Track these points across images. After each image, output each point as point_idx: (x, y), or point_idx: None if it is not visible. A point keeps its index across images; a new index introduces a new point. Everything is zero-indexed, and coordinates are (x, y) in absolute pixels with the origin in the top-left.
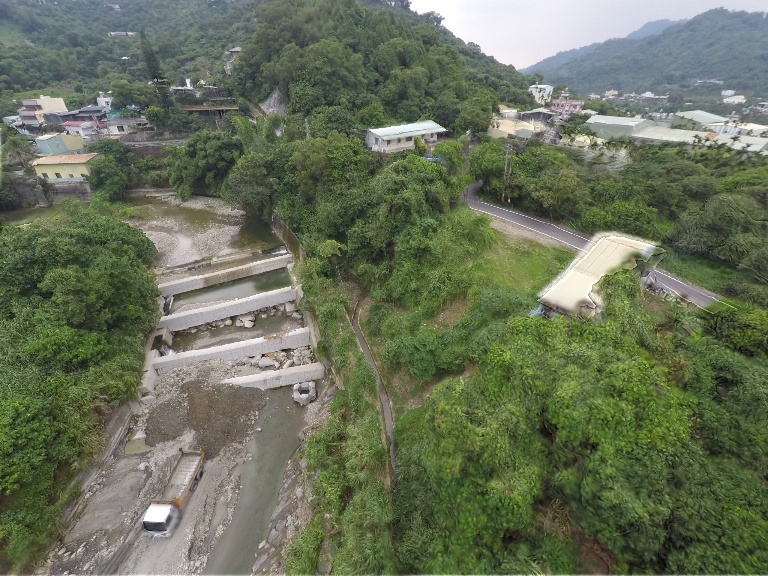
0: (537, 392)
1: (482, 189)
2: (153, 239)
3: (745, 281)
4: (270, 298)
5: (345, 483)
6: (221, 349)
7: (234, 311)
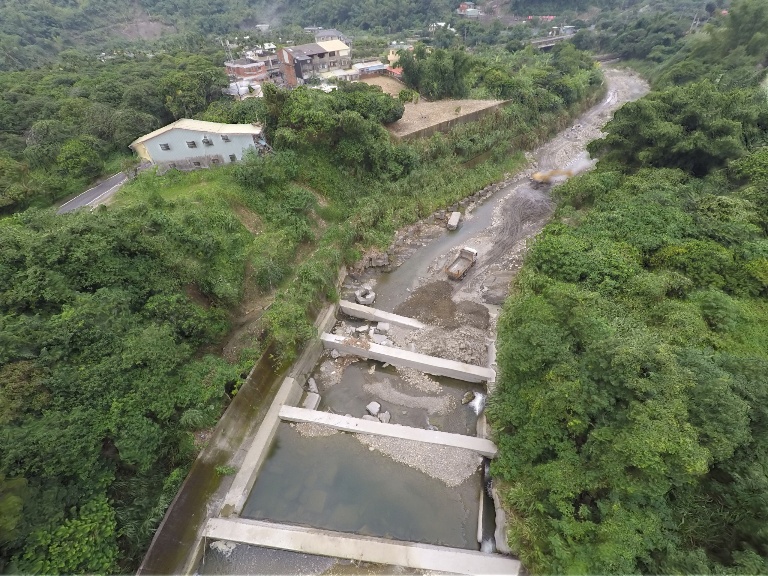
0: (327, 106)
1: None
2: None
3: (116, 155)
4: None
5: None
6: (417, 355)
7: None
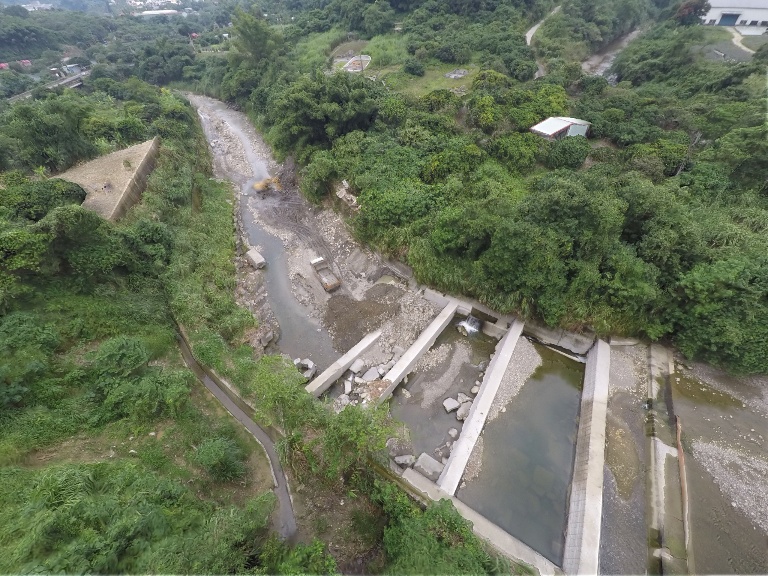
0: None
1: None
2: None
3: None
4: None
5: None
6: (416, 344)
7: None
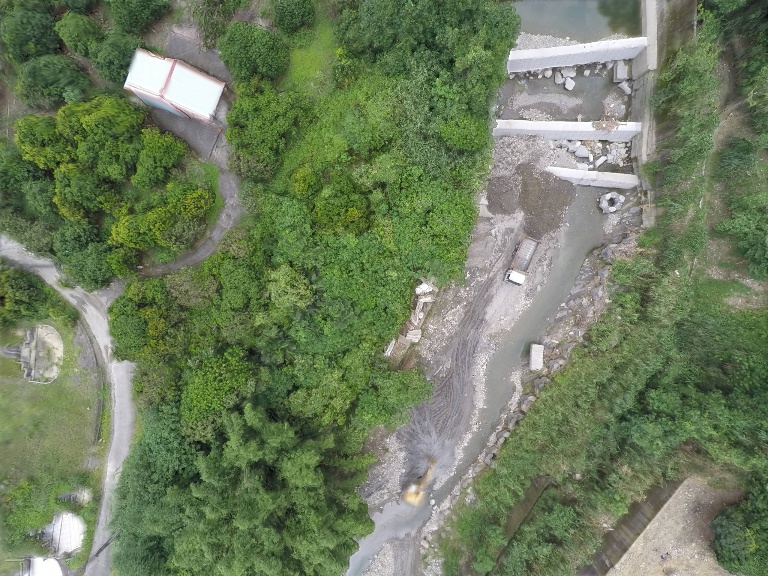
0: None
1: None
2: None
3: None
4: (609, 53)
5: (642, 309)
6: (549, 127)
7: (562, 61)
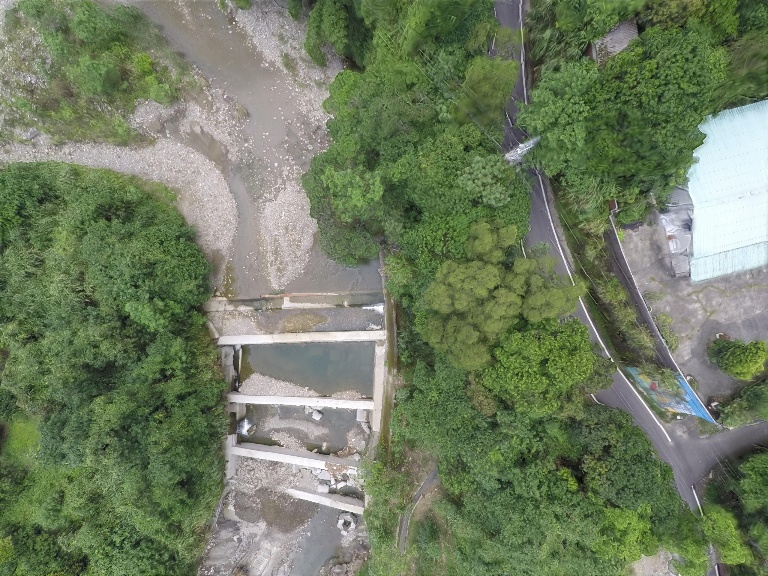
0: None
1: (742, 455)
2: (203, 194)
3: None
4: (341, 407)
5: None
6: (286, 461)
7: None
